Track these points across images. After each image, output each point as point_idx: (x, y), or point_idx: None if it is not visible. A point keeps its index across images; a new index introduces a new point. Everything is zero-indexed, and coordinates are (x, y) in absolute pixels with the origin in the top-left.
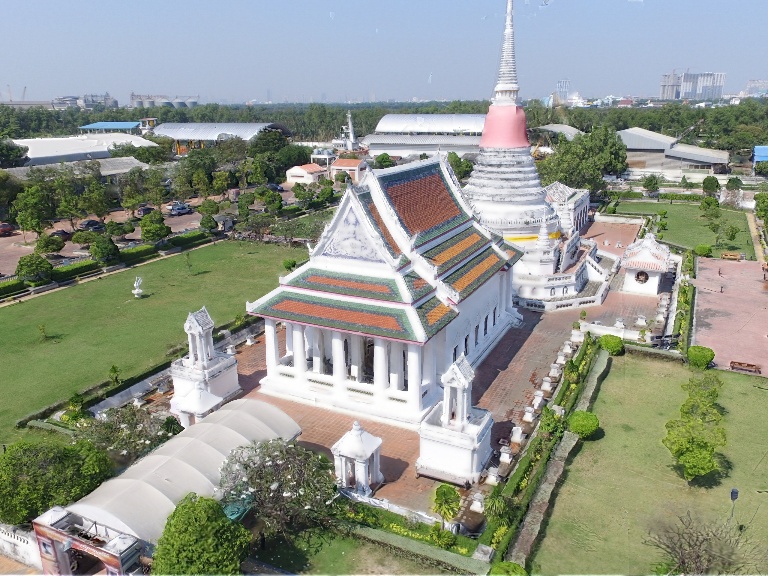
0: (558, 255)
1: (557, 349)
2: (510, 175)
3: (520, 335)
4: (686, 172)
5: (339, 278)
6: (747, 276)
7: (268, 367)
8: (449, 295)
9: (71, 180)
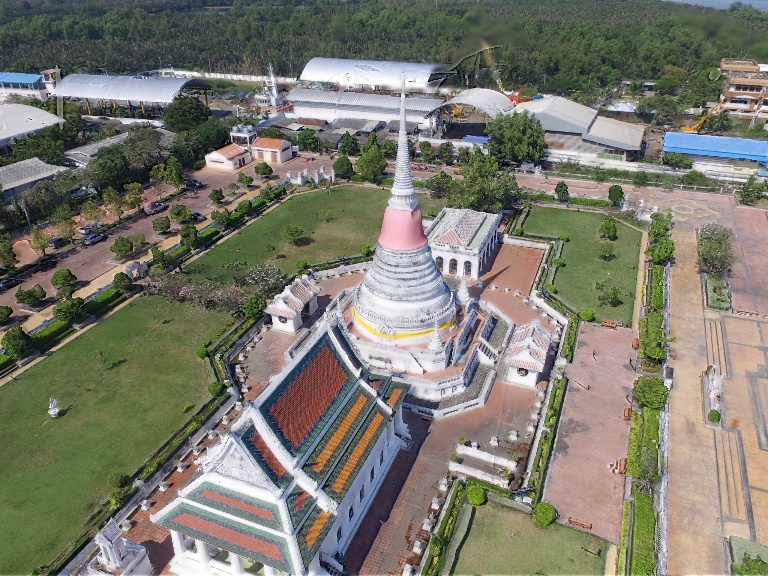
0: (451, 349)
1: (435, 484)
2: (407, 275)
3: (406, 462)
4: (601, 157)
5: (231, 496)
6: (616, 358)
7: (176, 554)
8: (328, 504)
9: None
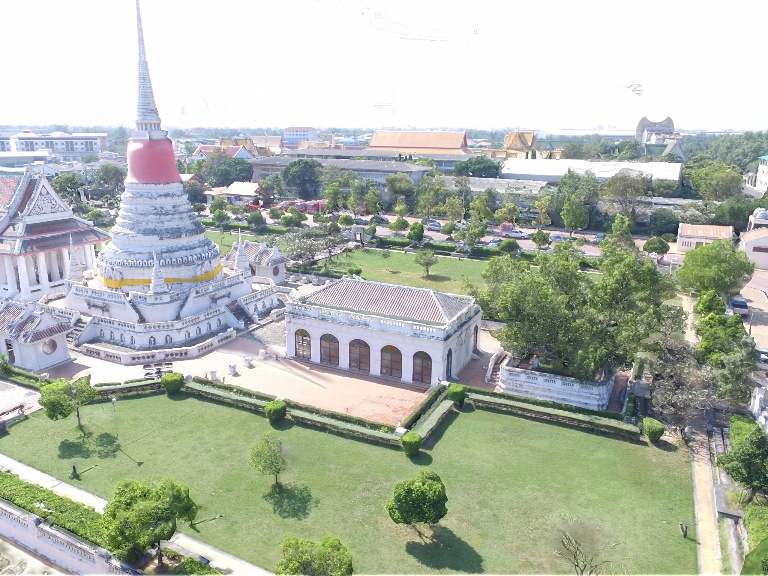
0: None
1: None
2: None
3: None
4: None
5: None
6: None
7: None
8: None
9: (360, 183)
